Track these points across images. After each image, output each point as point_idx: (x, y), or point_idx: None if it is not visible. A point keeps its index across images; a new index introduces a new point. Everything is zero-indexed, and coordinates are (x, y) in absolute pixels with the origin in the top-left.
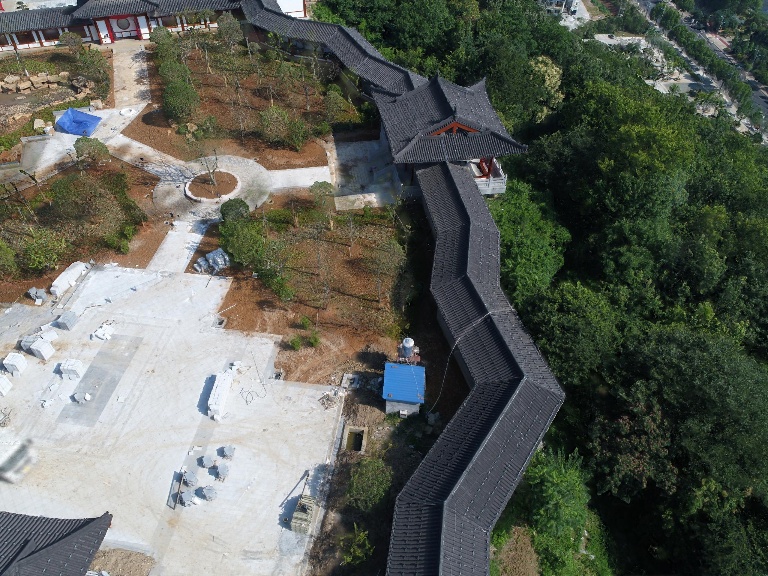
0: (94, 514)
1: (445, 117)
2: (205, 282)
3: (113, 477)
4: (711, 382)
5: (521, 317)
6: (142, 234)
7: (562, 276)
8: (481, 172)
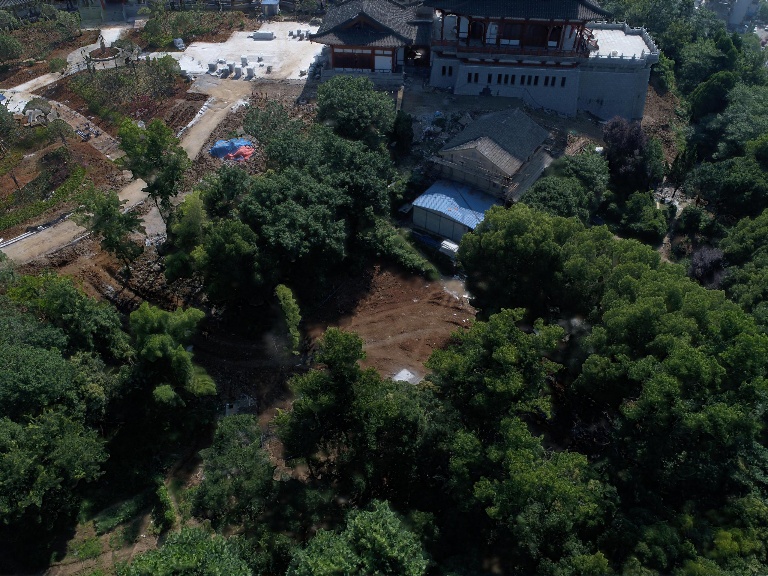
0: (313, 50)
1: None
2: (193, 47)
3: None
4: None
5: None
6: None
7: None
8: None
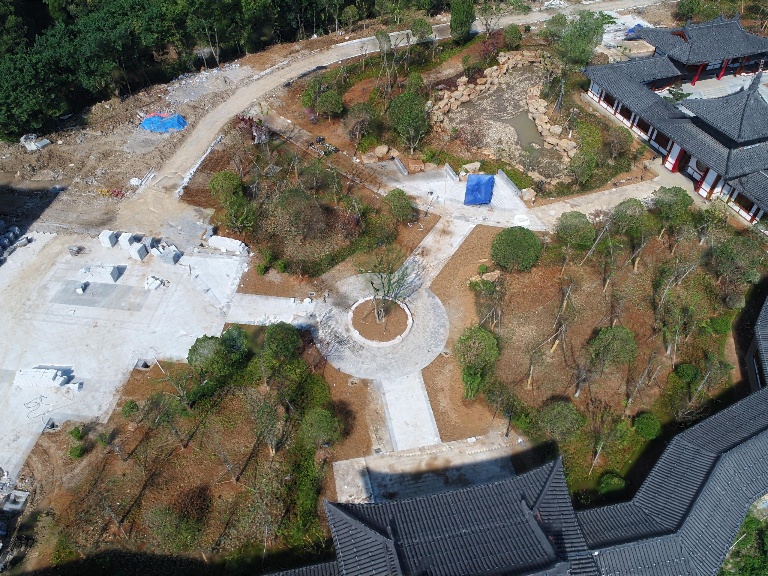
0: None
1: None
2: None
3: None
4: None
5: None
6: (290, 279)
7: None
8: None
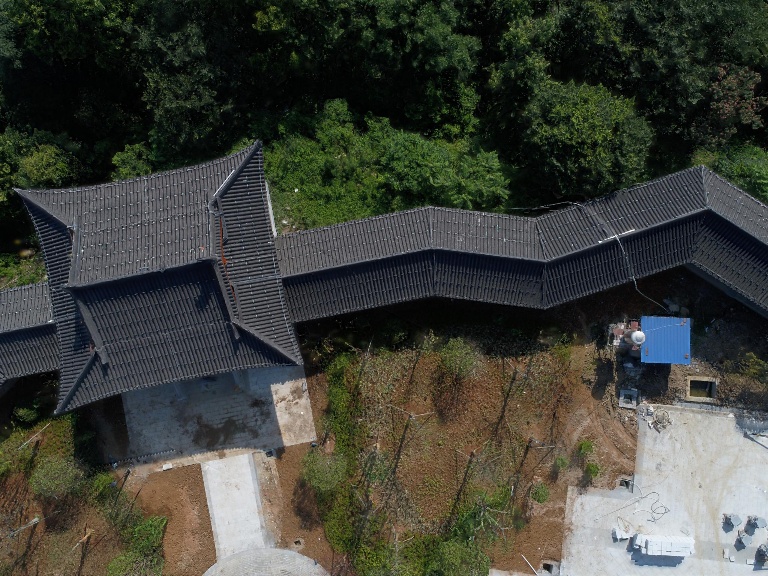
0: None
1: (200, 277)
2: None
3: None
4: (714, 4)
5: (517, 192)
6: None
7: (395, 124)
8: None
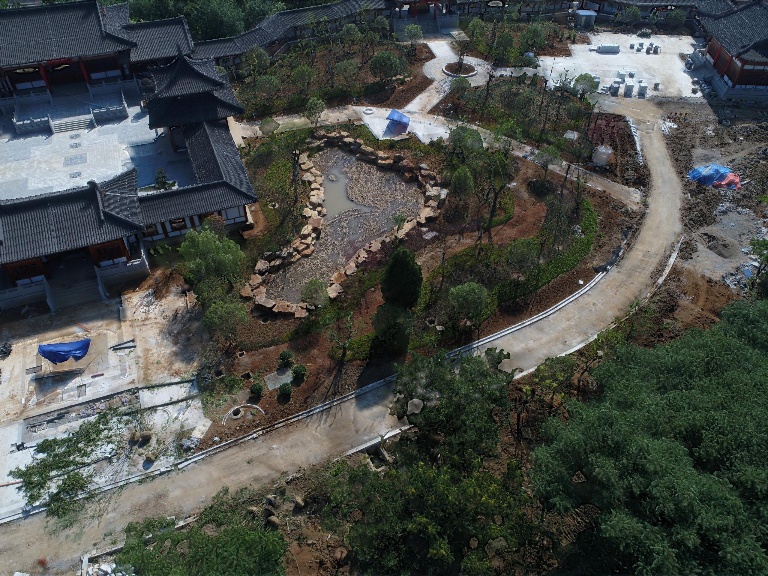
0: None
1: None
2: (545, 61)
3: (658, 64)
4: None
5: None
6: None
7: None
8: (431, 5)
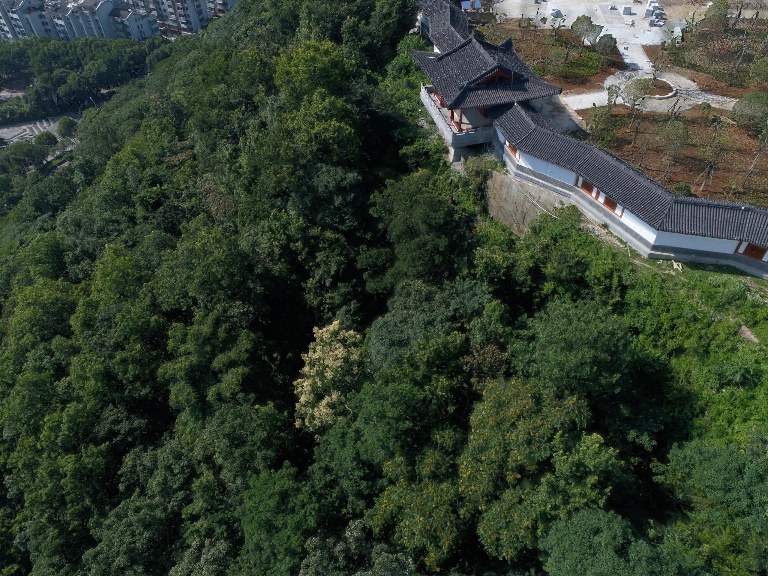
0: None
1: None
2: None
3: None
4: None
5: None
6: None
7: None
8: None
